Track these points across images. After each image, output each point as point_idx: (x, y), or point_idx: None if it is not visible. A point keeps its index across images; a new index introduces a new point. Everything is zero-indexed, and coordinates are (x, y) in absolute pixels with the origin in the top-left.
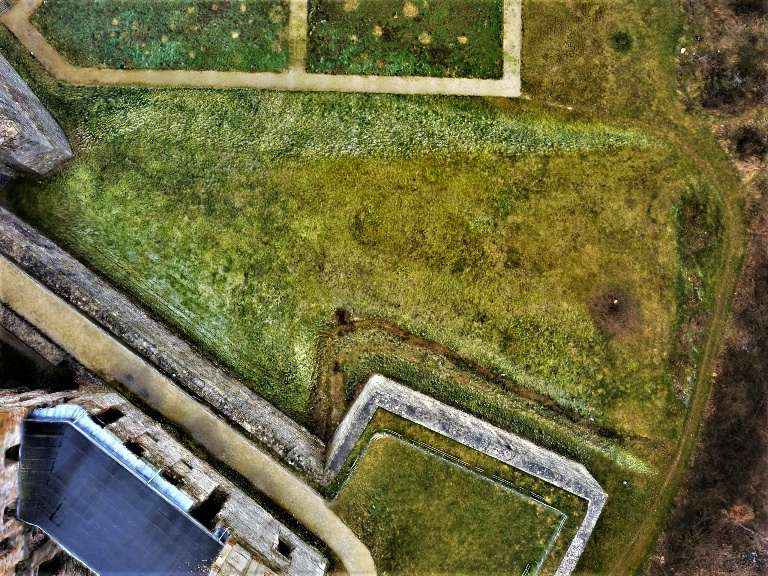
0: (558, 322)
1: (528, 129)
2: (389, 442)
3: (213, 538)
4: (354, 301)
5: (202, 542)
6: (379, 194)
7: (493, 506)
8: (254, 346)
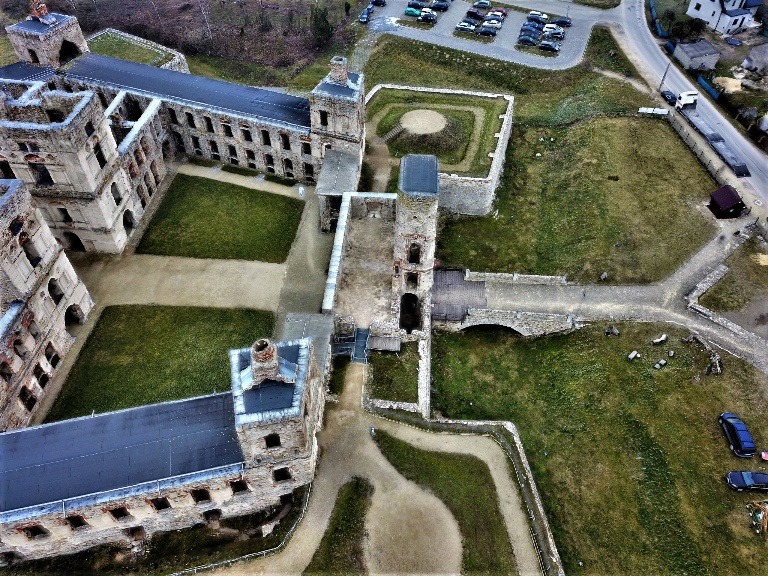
0: None
1: None
2: None
3: None
4: None
5: (14, 65)
6: None
7: None
8: None
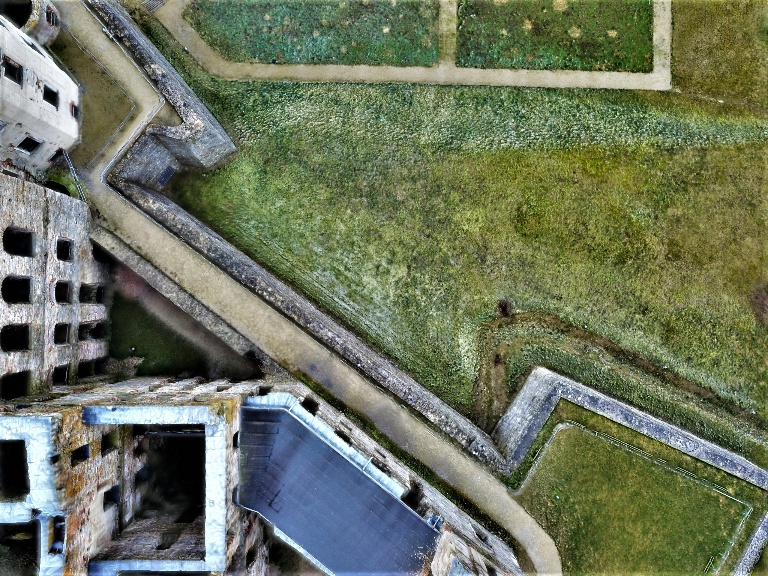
0: (720, 315)
1: (681, 122)
2: (572, 433)
3: (428, 525)
4: (516, 293)
5: (418, 529)
6: (540, 187)
7: (677, 497)
8: (418, 338)
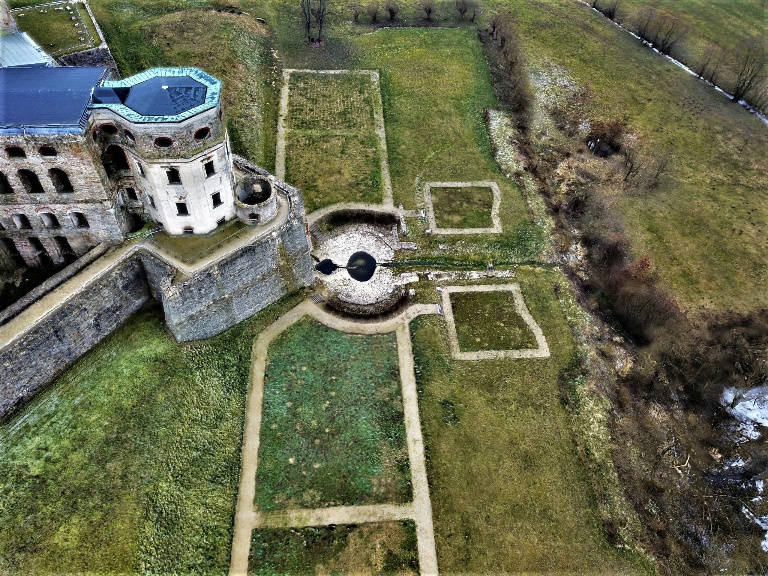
0: None
1: None
2: None
3: None
4: None
5: None
6: None
7: None
8: None
